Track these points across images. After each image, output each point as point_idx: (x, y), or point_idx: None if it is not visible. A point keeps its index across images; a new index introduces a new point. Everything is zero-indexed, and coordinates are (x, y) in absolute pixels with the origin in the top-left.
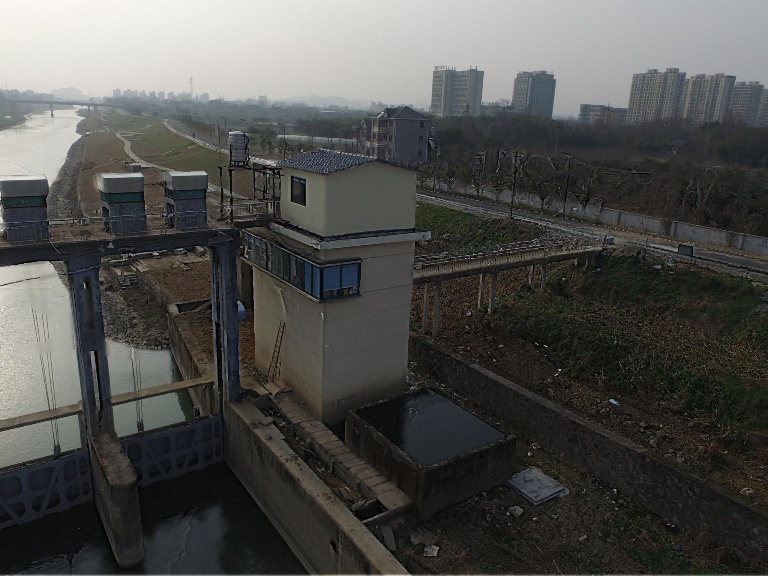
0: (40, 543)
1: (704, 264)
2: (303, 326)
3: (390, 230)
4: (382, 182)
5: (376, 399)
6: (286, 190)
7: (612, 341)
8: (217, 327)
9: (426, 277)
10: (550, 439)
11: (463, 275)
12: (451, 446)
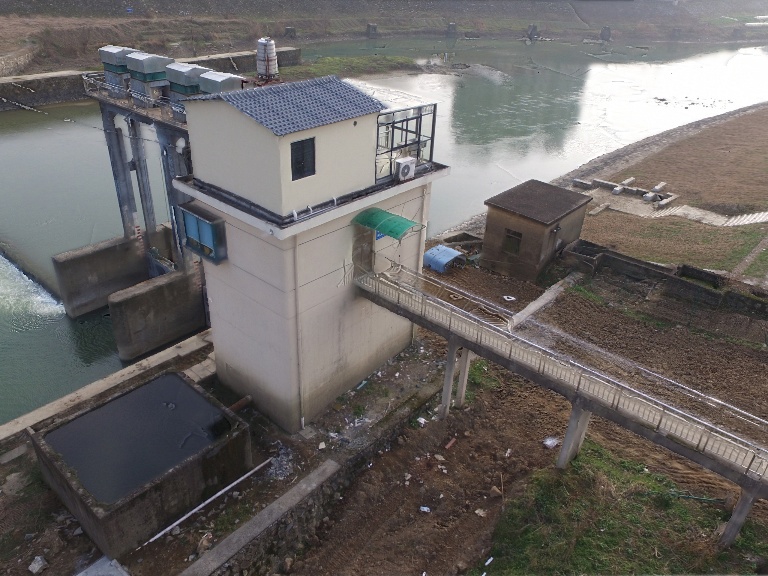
0: None
1: None
2: None
3: (253, 203)
4: (240, 133)
5: (261, 398)
6: None
7: None
8: None
9: (428, 320)
10: None
11: (498, 360)
12: (123, 466)
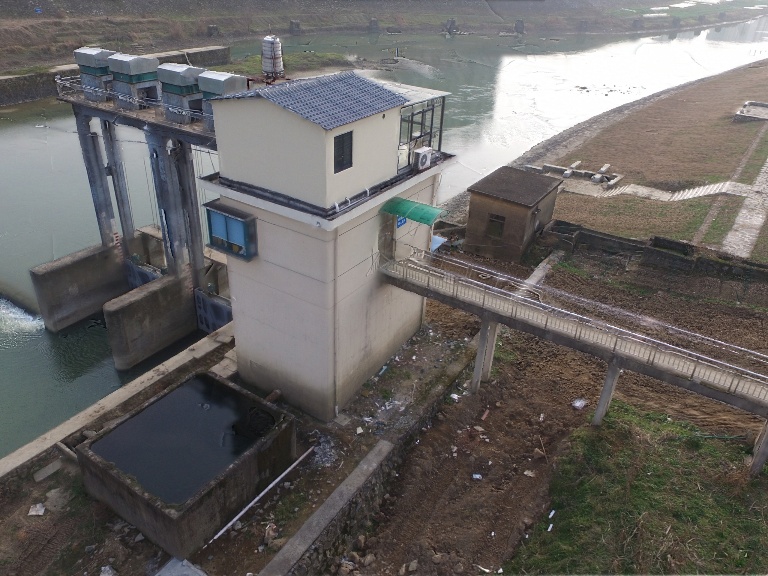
0: None
1: None
2: None
3: (292, 198)
4: (279, 129)
5: (292, 391)
6: None
7: None
8: None
9: (460, 300)
10: None
11: (533, 331)
12: (176, 469)
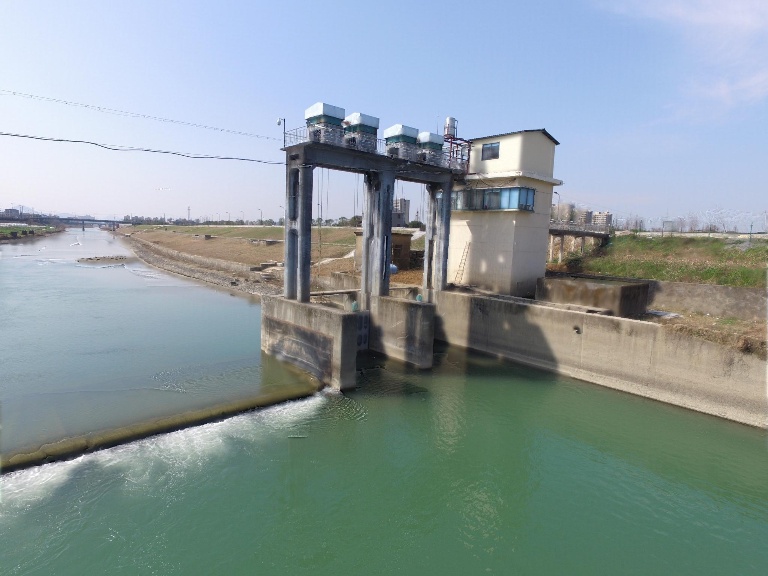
0: (358, 361)
1: (678, 234)
2: (492, 237)
3: None
4: (542, 145)
5: (532, 288)
6: (477, 155)
7: (652, 263)
8: (429, 244)
9: None
10: (652, 299)
11: (550, 232)
12: None
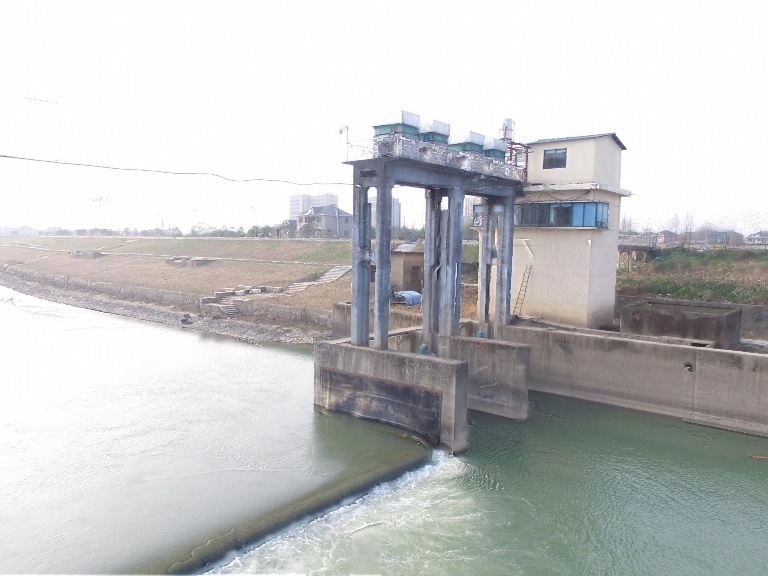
0: None
1: (731, 246)
2: (561, 259)
3: None
4: (611, 152)
5: (605, 318)
6: (537, 162)
7: (719, 282)
8: (487, 269)
9: None
10: None
11: None
12: None
